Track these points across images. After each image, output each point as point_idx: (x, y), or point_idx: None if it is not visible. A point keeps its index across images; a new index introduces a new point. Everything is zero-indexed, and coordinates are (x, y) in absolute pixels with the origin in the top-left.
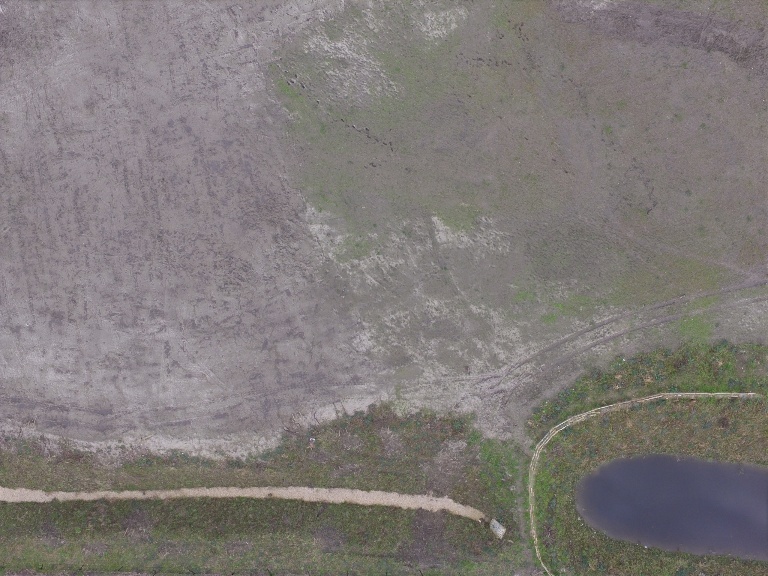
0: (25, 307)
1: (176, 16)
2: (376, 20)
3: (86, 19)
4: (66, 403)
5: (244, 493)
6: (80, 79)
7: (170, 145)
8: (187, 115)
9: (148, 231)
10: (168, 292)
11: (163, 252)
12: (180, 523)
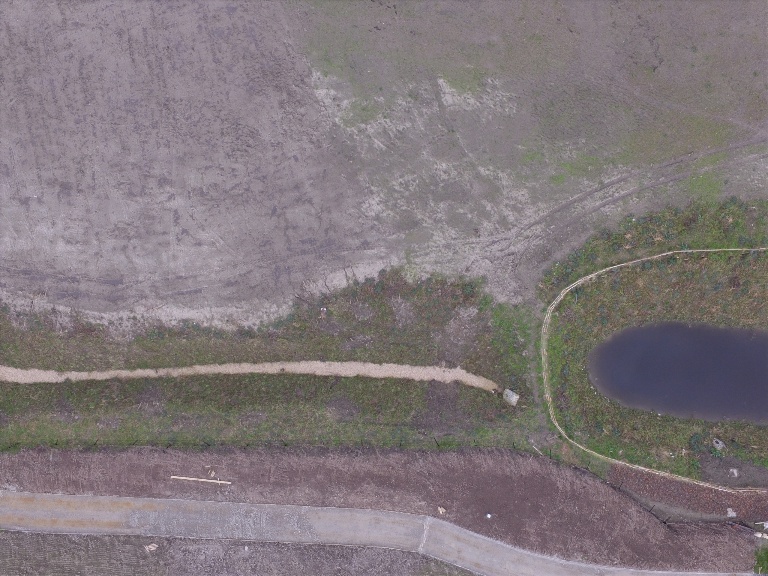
0: (33, 178)
1: None
2: None
3: None
4: (77, 274)
5: (256, 369)
6: None
7: (174, 13)
8: None
9: (154, 99)
10: (176, 160)
11: (170, 120)
12: (193, 397)
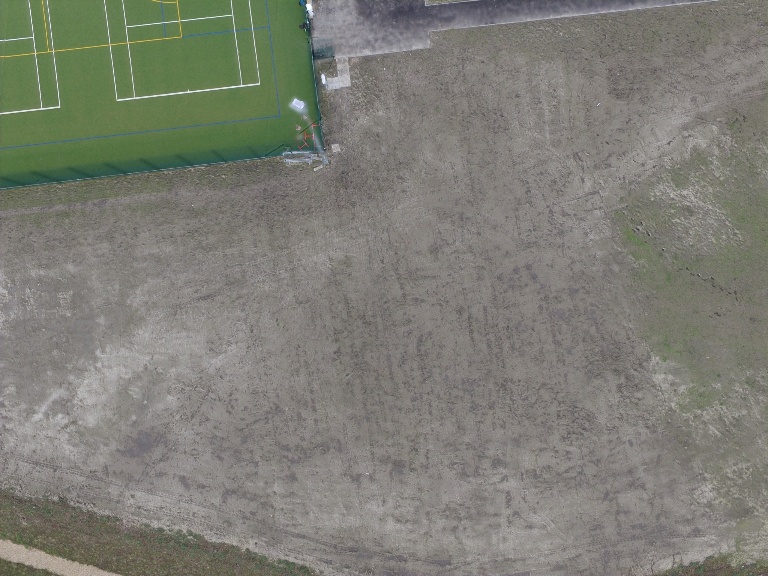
0: (366, 455)
1: (522, 161)
2: (722, 168)
3: (430, 162)
4: (404, 553)
5: None
6: (424, 223)
7: (515, 292)
8: (533, 262)
9: (492, 379)
10: (511, 441)
11: (506, 401)
12: None
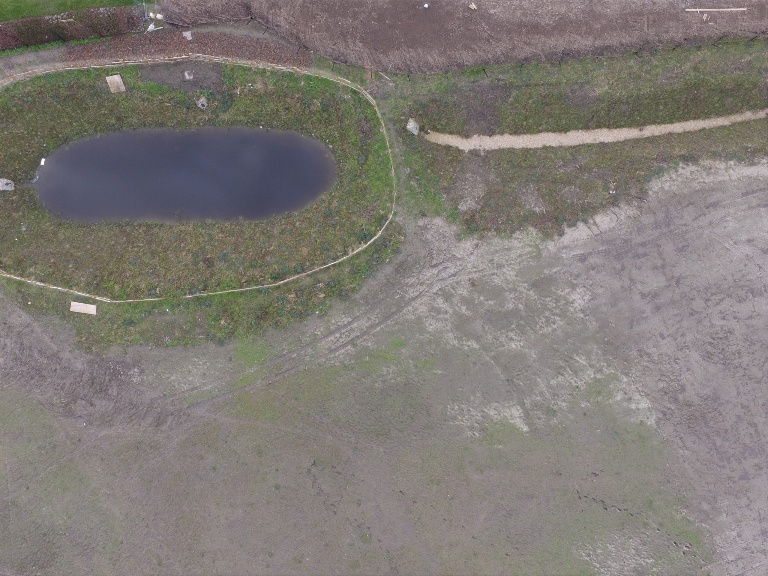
0: None
1: None
2: None
3: None
4: None
5: (667, 128)
6: None
7: None
8: None
9: None
10: None
11: None
12: (732, 91)
